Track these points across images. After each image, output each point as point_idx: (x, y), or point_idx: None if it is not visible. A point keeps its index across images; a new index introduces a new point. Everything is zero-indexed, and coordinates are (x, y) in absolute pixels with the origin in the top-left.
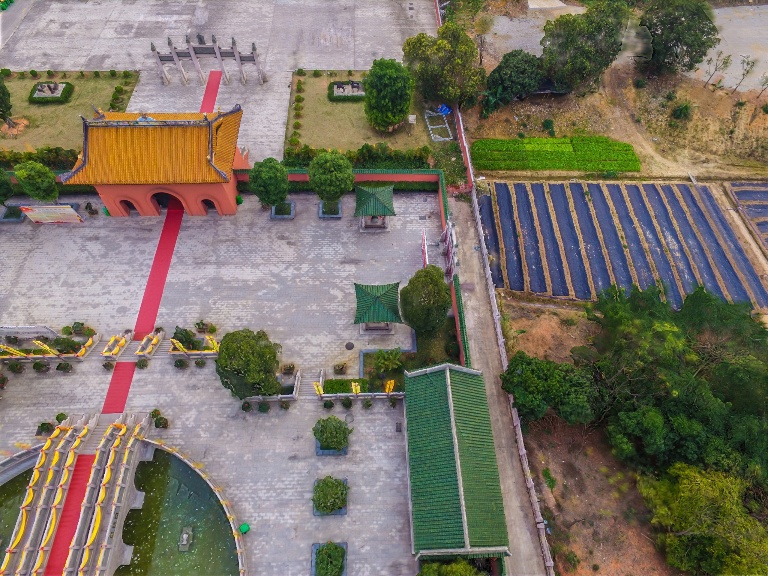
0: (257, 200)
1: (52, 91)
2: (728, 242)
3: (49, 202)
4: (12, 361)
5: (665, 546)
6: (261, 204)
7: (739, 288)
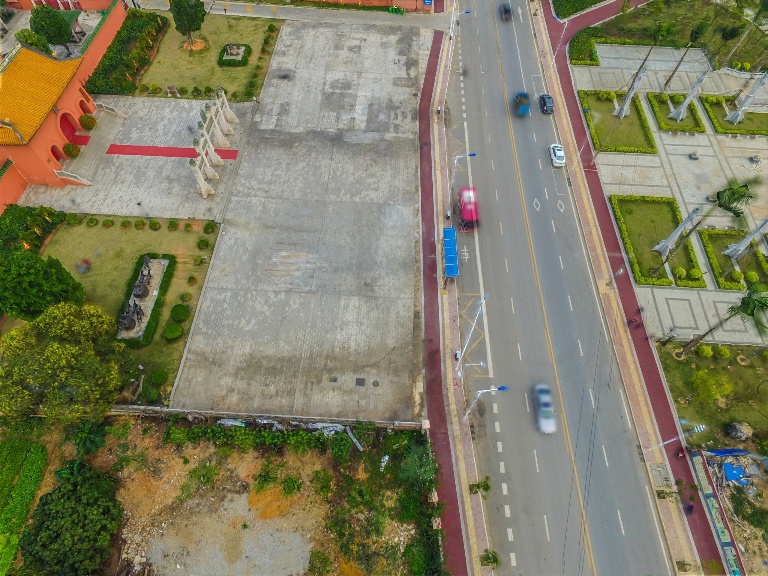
0: None
1: (227, 53)
2: None
3: None
4: None
5: None
6: None
7: None
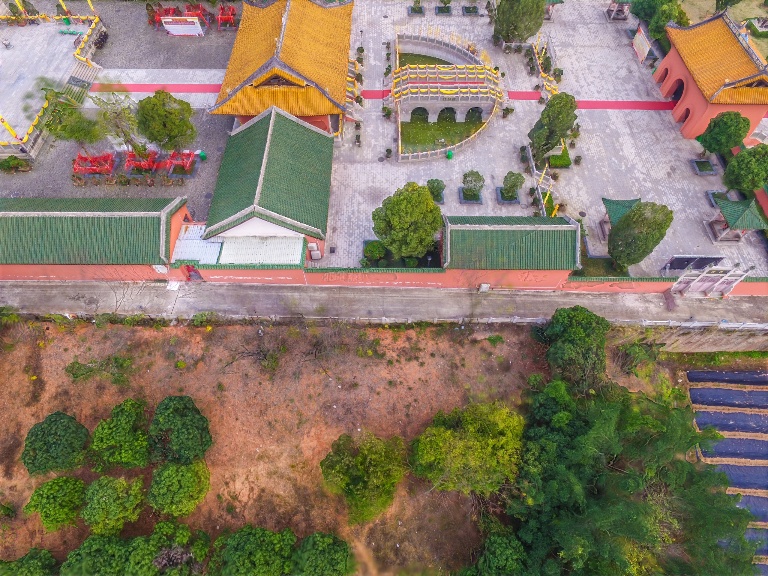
0: None
1: (762, 25)
2: None
3: (649, 36)
4: (532, 51)
5: None
6: None
7: None
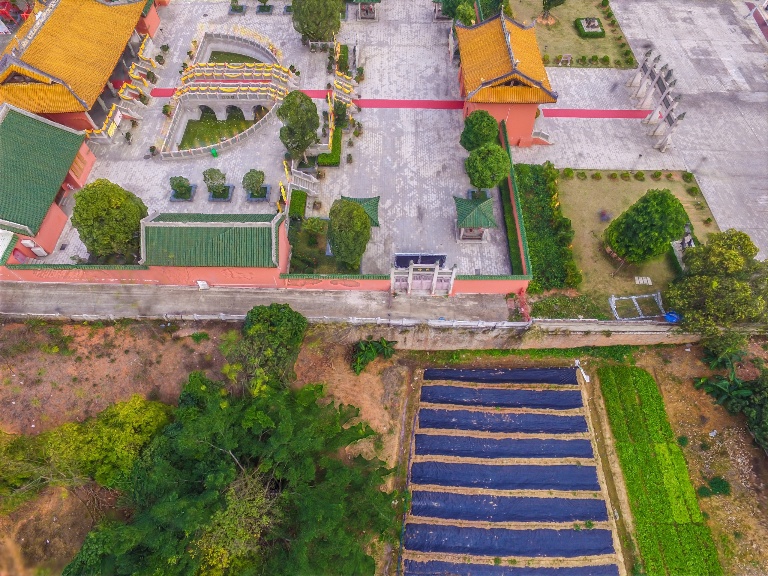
0: None
1: (588, 25)
2: None
3: None
4: None
5: None
6: None
7: None
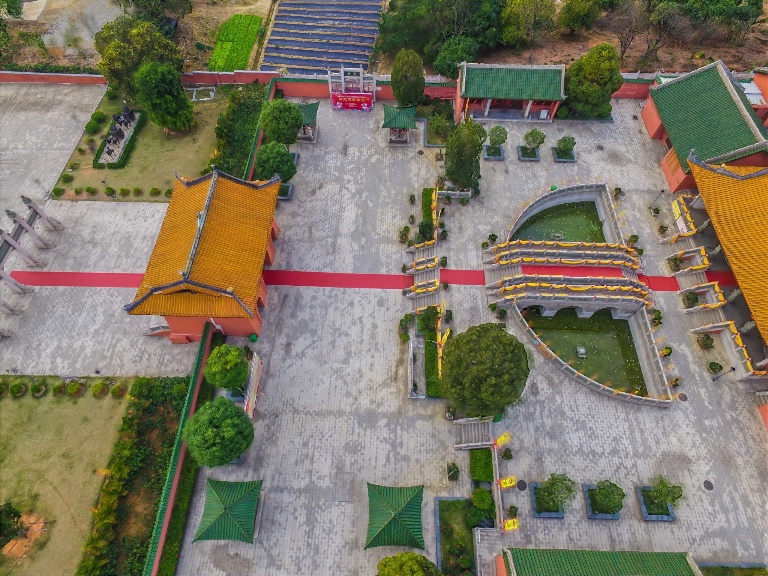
0: None
1: None
2: (331, 1)
3: None
4: None
5: (533, 40)
6: None
7: (366, 7)
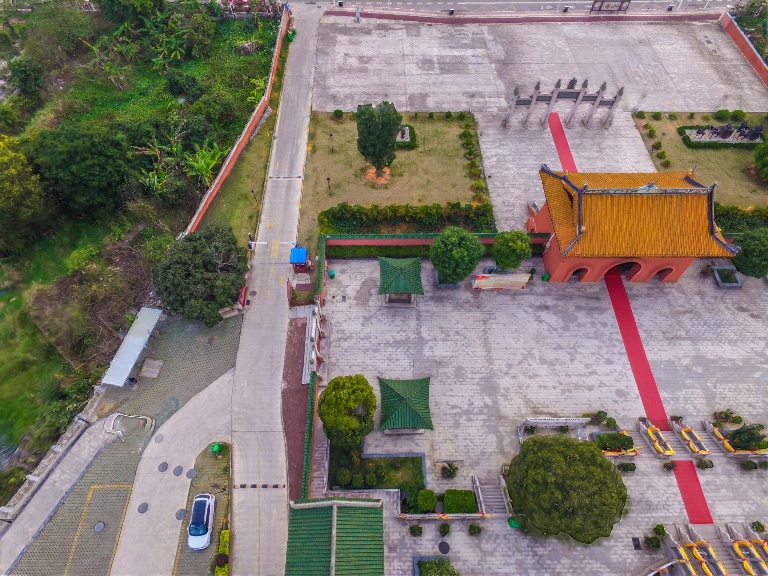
0: (690, 264)
1: (403, 136)
2: None
3: (512, 271)
4: None
5: None
6: (702, 270)
7: None
